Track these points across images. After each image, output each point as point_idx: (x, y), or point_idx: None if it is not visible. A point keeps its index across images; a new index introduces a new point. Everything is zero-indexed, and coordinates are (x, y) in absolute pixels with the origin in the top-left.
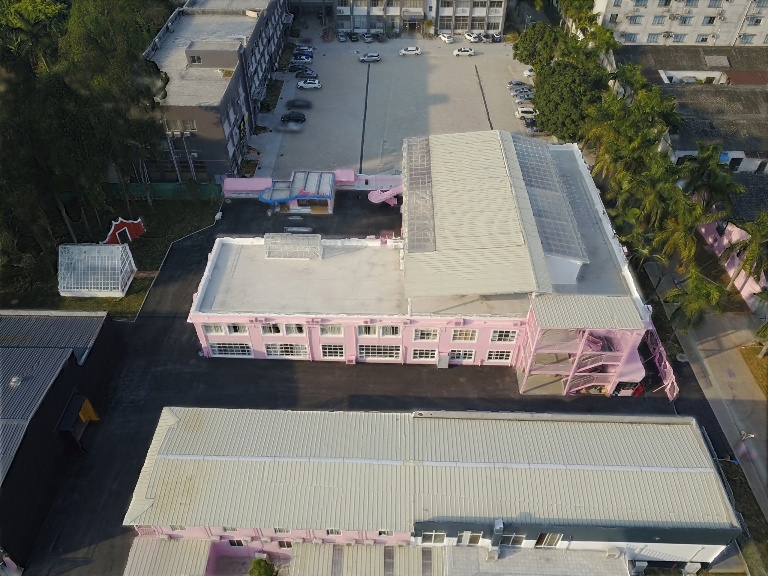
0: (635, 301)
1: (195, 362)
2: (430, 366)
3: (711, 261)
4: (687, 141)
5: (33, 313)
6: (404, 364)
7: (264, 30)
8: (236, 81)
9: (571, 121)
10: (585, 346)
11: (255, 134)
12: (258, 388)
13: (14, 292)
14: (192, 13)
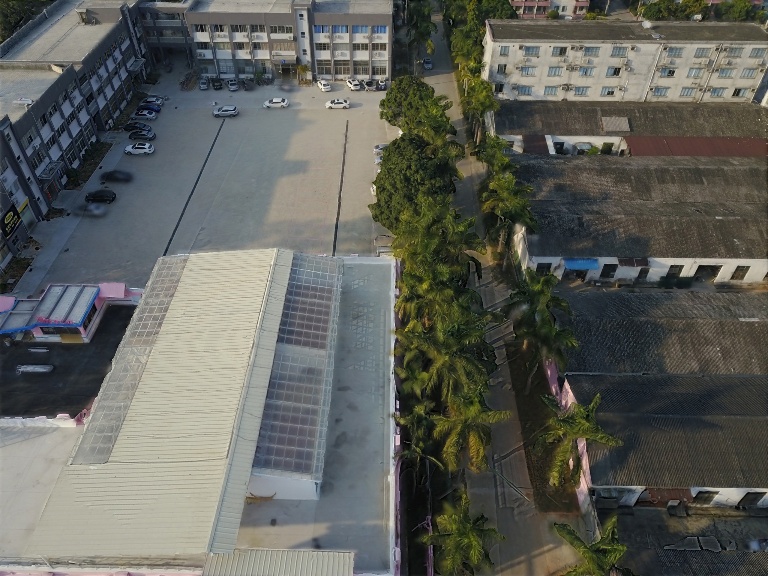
0: (389, 532)
1: None
2: None
3: (548, 424)
4: (547, 244)
5: None
6: None
7: (78, 87)
8: None
9: None
10: None
11: (45, 220)
12: None
13: None
14: None
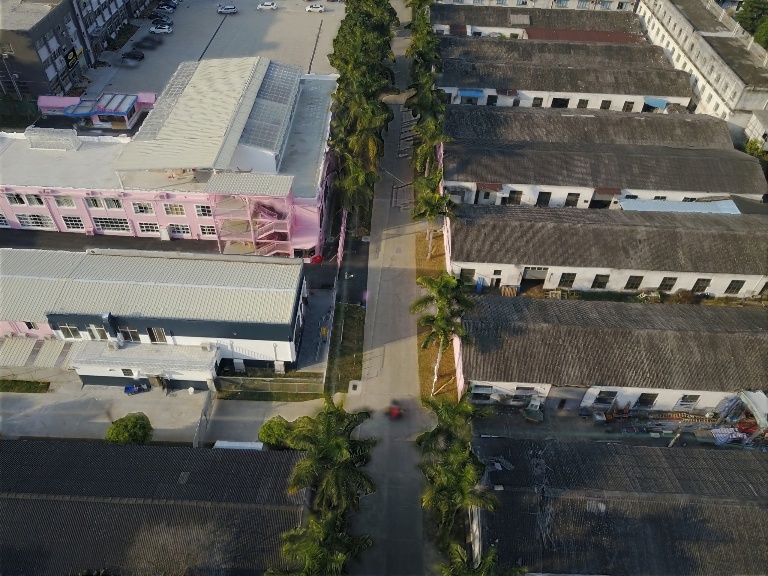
0: (317, 187)
1: None
2: (156, 239)
3: None
4: (449, 79)
5: None
6: (135, 237)
7: None
8: (61, 14)
9: None
10: (255, 214)
11: (93, 67)
12: None
13: None
14: None
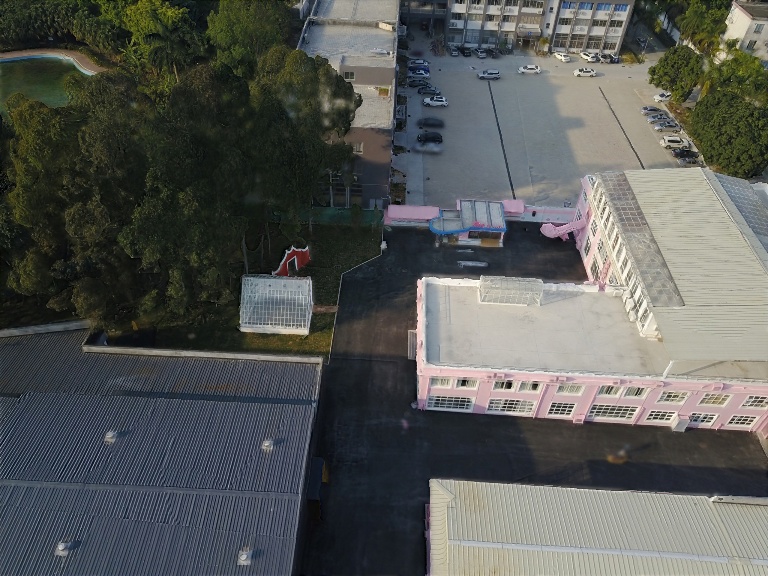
0: None
1: (410, 415)
2: (663, 428)
3: None
4: None
5: (239, 356)
6: (634, 425)
7: None
8: None
9: (748, 157)
10: None
11: (394, 154)
12: (486, 448)
13: (188, 325)
14: (322, 23)
